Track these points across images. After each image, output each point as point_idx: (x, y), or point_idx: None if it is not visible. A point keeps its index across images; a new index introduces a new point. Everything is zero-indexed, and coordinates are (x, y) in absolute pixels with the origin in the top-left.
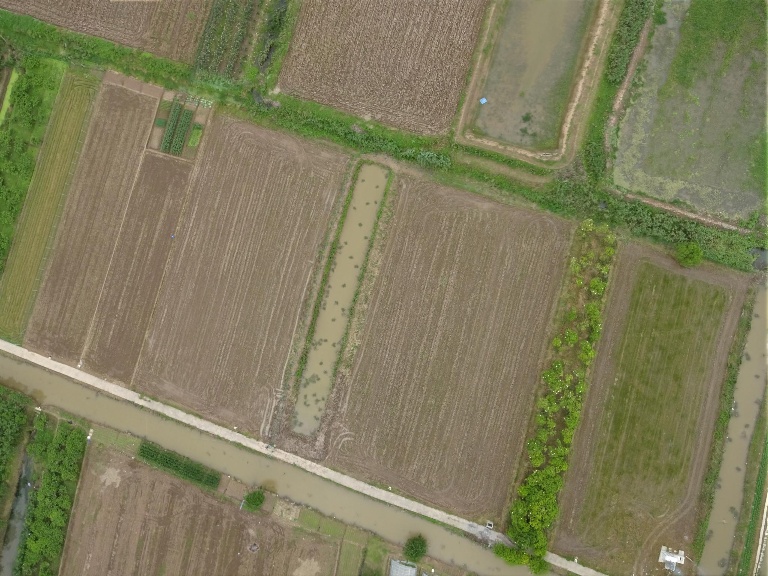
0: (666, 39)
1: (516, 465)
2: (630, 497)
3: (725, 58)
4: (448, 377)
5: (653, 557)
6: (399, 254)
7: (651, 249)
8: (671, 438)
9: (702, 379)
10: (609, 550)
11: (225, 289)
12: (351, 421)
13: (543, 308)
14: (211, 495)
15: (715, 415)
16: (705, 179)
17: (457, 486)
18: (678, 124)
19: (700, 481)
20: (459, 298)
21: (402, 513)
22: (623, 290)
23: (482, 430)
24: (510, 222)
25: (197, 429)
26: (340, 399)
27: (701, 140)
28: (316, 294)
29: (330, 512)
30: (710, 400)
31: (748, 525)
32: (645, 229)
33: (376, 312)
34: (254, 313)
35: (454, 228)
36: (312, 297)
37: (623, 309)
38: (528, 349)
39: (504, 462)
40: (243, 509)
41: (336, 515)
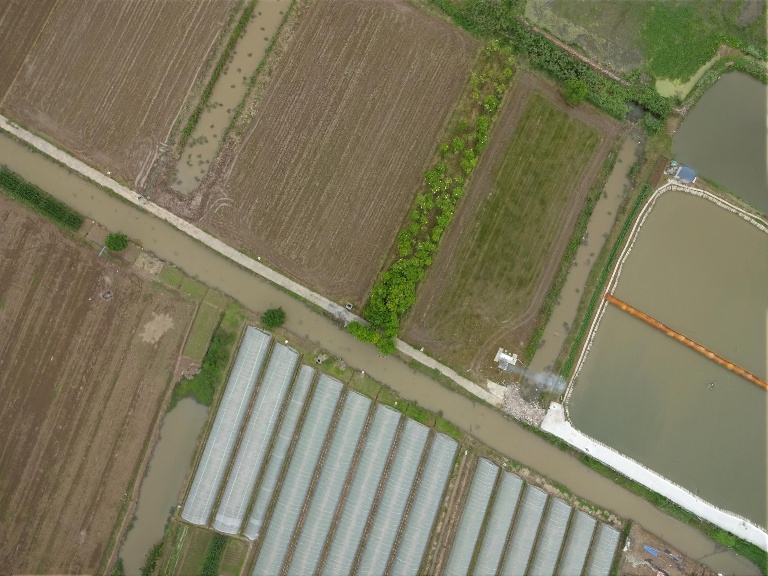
0: None
1: (384, 256)
2: (481, 300)
3: None
4: (336, 163)
5: (490, 356)
6: (311, 36)
7: (544, 83)
8: (527, 255)
9: (564, 207)
10: (453, 345)
11: (123, 31)
12: (232, 188)
13: (438, 116)
14: (70, 236)
15: (568, 241)
16: (603, 31)
17: (325, 267)
18: None
19: (544, 296)
20: (361, 90)
21: (267, 284)
22: (513, 115)
23: (359, 218)
24: (424, 29)
25: (66, 167)
26: (225, 164)
27: None
28: (220, 56)
29: (194, 273)
30: (567, 227)
31: (575, 339)
32: (543, 61)
33: (278, 87)
34: (150, 62)
35: (370, 23)
36: (215, 58)
37: (509, 132)
38: (417, 151)
39: (374, 251)
40: (103, 256)
41: (200, 277)
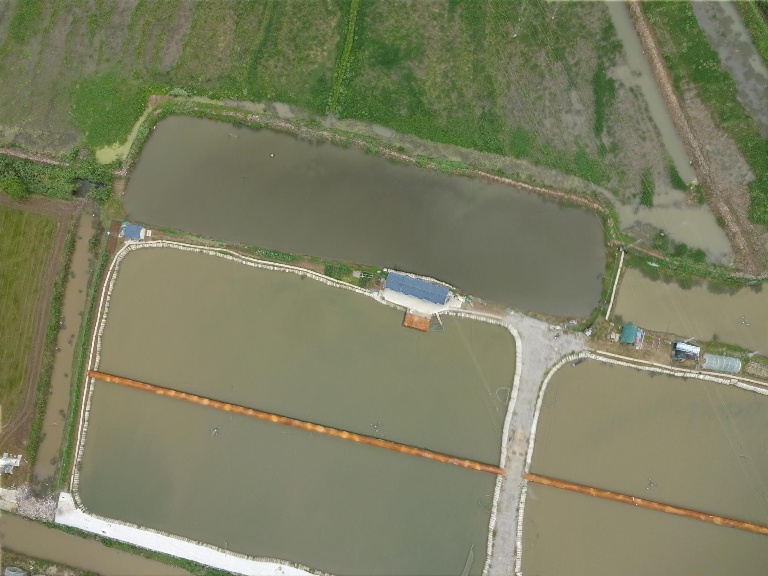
0: (5, 6)
1: None
2: None
3: (50, 17)
4: None
5: None
6: None
7: None
8: (12, 355)
9: (37, 300)
10: None
11: None
12: None
13: None
14: None
15: (46, 330)
16: (36, 124)
17: None
18: (14, 78)
19: (35, 390)
20: None
21: None
22: None
23: None
24: None
25: None
26: None
27: (32, 90)
28: None
29: None
30: (43, 317)
31: (70, 424)
32: None
33: None
34: None
35: None
36: None
37: None
38: None
39: None
40: None
41: None
